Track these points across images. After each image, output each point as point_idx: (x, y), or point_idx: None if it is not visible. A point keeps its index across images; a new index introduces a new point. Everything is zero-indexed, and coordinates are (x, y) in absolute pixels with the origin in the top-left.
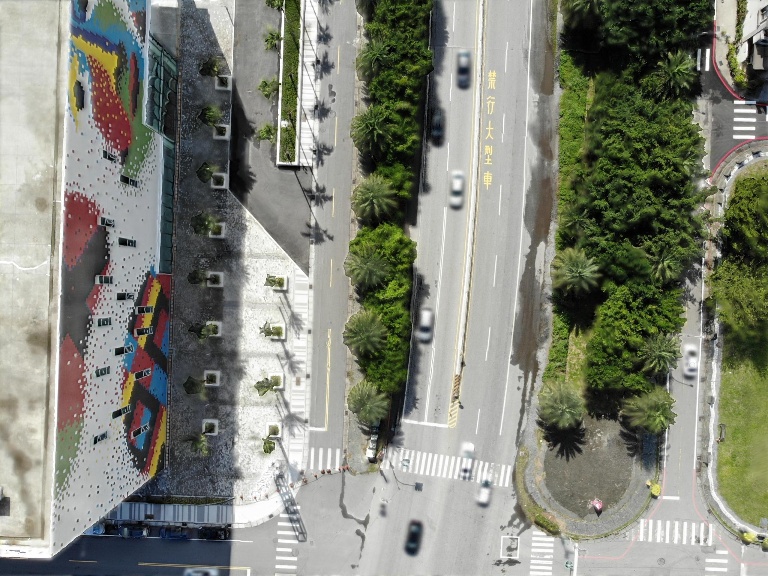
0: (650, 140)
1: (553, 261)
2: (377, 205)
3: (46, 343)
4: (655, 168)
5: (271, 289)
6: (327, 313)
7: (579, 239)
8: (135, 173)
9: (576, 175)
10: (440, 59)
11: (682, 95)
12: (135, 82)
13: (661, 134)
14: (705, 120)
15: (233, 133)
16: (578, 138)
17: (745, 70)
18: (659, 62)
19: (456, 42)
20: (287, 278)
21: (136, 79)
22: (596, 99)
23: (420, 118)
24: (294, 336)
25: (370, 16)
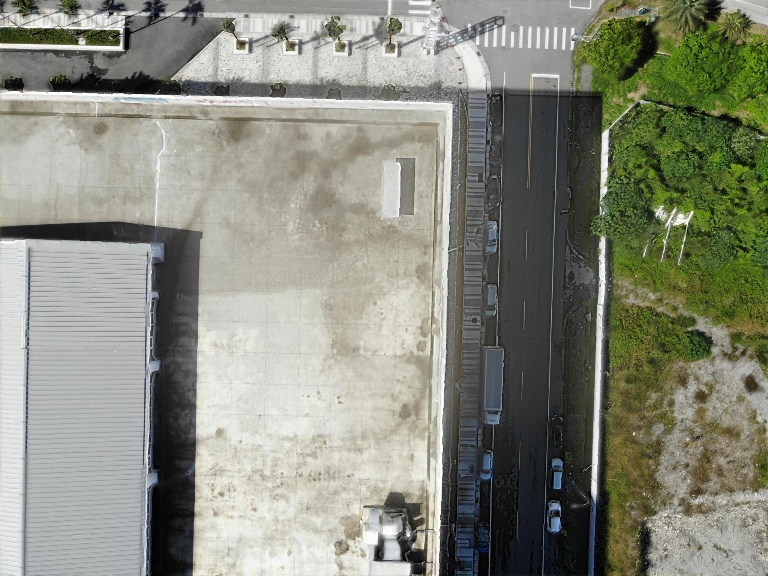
0: None
1: None
2: None
3: (240, 123)
4: None
5: (249, 55)
6: None
7: None
8: None
9: None
10: None
11: None
12: None
13: None
14: None
15: None
16: None
17: None
18: None
19: None
20: None
21: None
22: None
23: None
24: (296, 33)
25: None
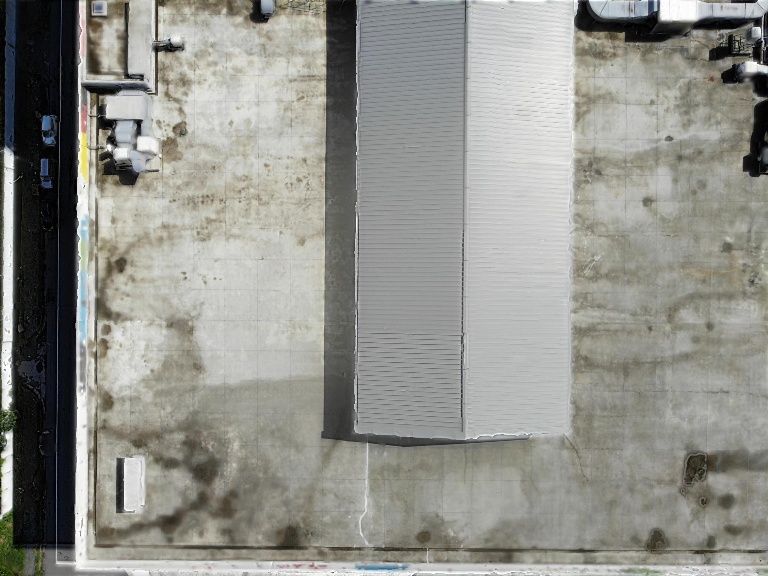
0: None
1: None
2: None
3: (288, 544)
4: None
5: None
6: None
7: None
8: None
9: None
10: None
11: None
12: None
13: None
14: None
15: None
16: None
17: None
18: None
19: None
20: None
21: None
22: None
23: None
24: None
25: None
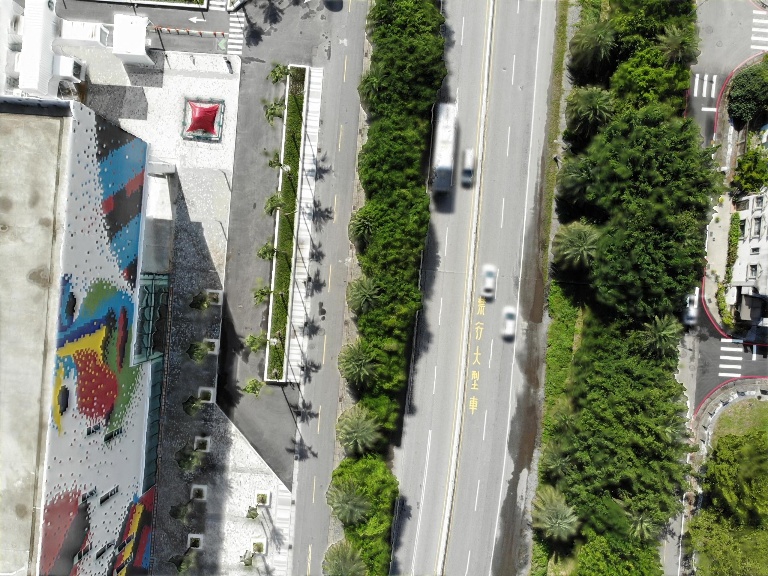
0: (633, 404)
1: (534, 498)
2: (361, 445)
3: None
4: (637, 433)
5: (254, 504)
6: (308, 529)
7: (560, 482)
8: (120, 420)
9: (560, 419)
10: (431, 283)
11: (668, 353)
12: (123, 333)
13: (644, 402)
14: (692, 356)
15: (222, 346)
16: (565, 367)
17: (733, 314)
18: (646, 323)
19: (447, 267)
20: (270, 493)
21: (125, 329)
22: (583, 344)
23: (409, 340)
24: (275, 550)
25: (362, 249)
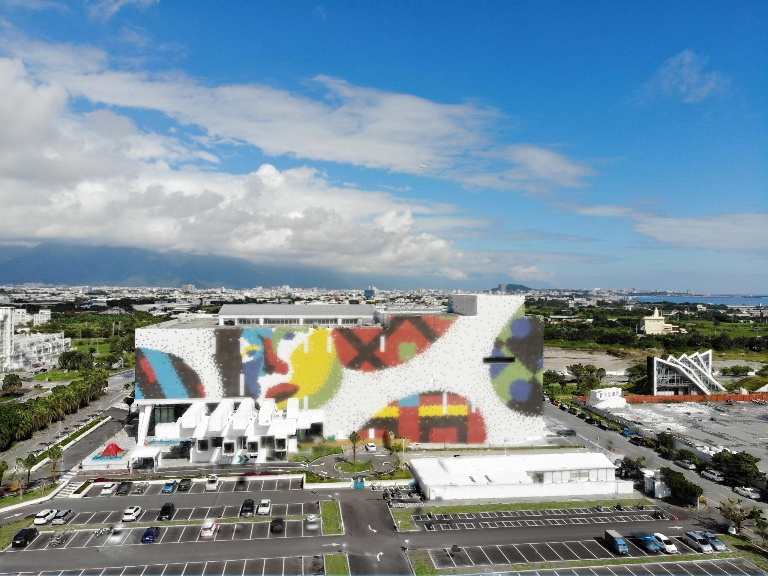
0: None
1: None
2: None
3: None
4: None
5: None
6: None
7: None
8: None
9: None
10: None
11: None
12: None
13: None
14: None
15: None
16: None
17: None
18: None
19: None
20: None
21: None
22: None
23: None
24: None
25: None
